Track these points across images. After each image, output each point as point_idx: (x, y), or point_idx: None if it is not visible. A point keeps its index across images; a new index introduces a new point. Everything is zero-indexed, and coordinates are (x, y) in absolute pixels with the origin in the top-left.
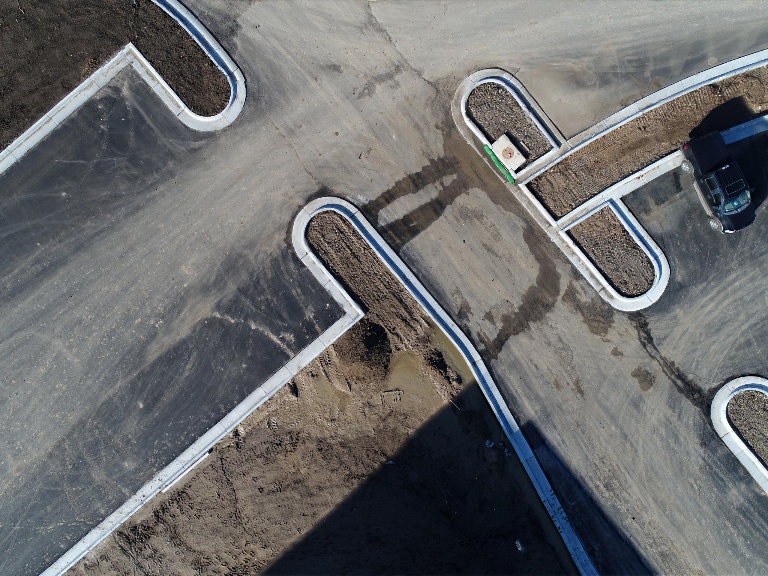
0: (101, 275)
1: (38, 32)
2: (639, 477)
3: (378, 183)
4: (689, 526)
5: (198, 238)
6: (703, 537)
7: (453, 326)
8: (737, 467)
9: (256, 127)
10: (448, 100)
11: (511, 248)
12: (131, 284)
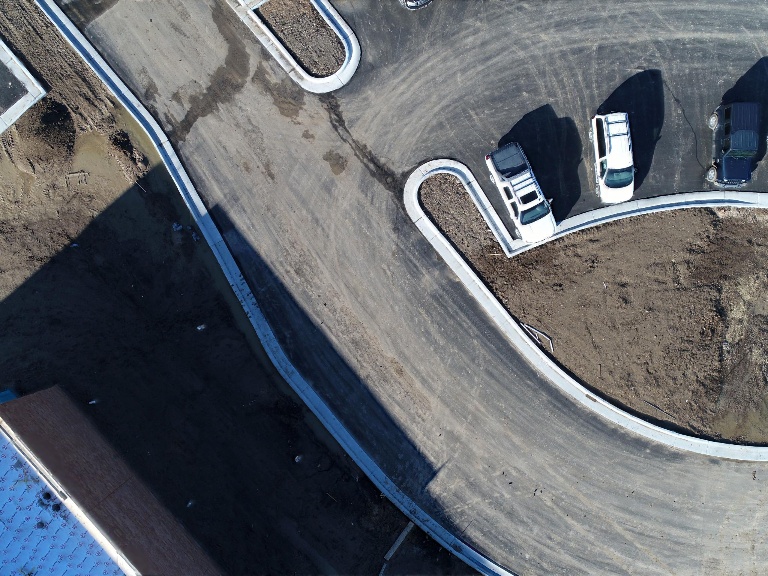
0: None
1: None
2: (331, 262)
3: None
4: (382, 313)
5: None
6: (396, 324)
7: (139, 106)
8: (431, 253)
9: None
10: None
11: (199, 28)
12: None
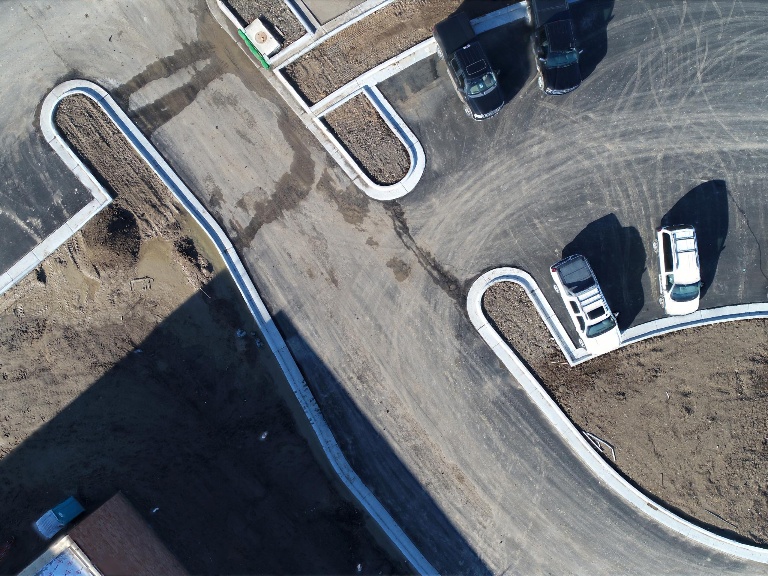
0: None
1: None
2: (394, 369)
3: (129, 66)
4: (444, 420)
5: None
6: (458, 431)
7: (204, 213)
8: (493, 360)
9: (3, 7)
10: None
11: (265, 135)
12: None
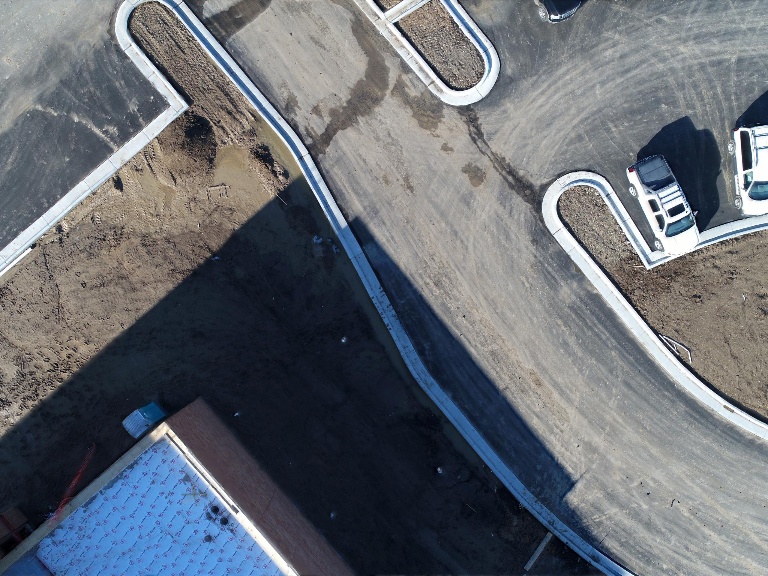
0: None
1: None
2: (470, 274)
3: None
4: (520, 324)
5: (19, 29)
6: (535, 336)
7: (280, 120)
8: (569, 264)
9: None
10: None
11: (339, 41)
12: None
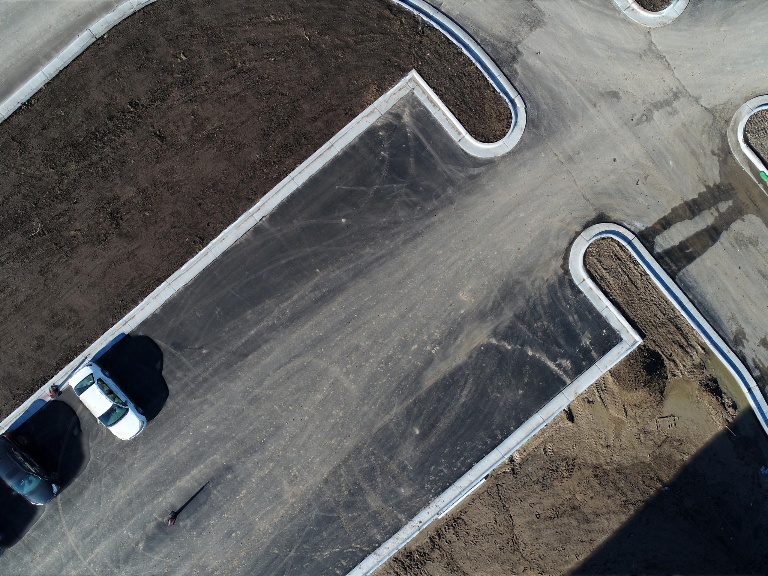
0: (379, 301)
1: (323, 59)
2: None
3: (655, 209)
4: None
5: (476, 264)
6: None
7: (729, 352)
8: None
9: (535, 153)
10: (724, 126)
11: None
12: (409, 310)
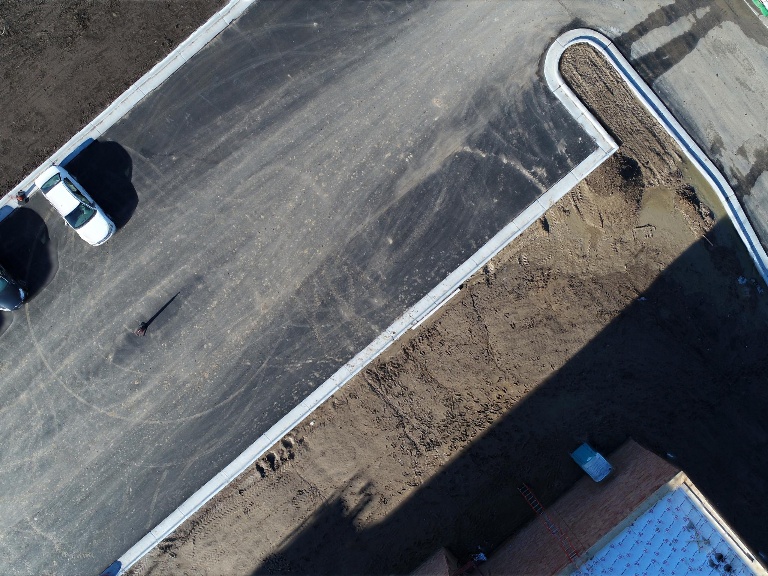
0: (352, 108)
1: None
2: None
3: (631, 15)
4: None
5: (450, 70)
6: None
7: (706, 161)
8: None
9: None
10: None
11: (764, 82)
12: (382, 117)
